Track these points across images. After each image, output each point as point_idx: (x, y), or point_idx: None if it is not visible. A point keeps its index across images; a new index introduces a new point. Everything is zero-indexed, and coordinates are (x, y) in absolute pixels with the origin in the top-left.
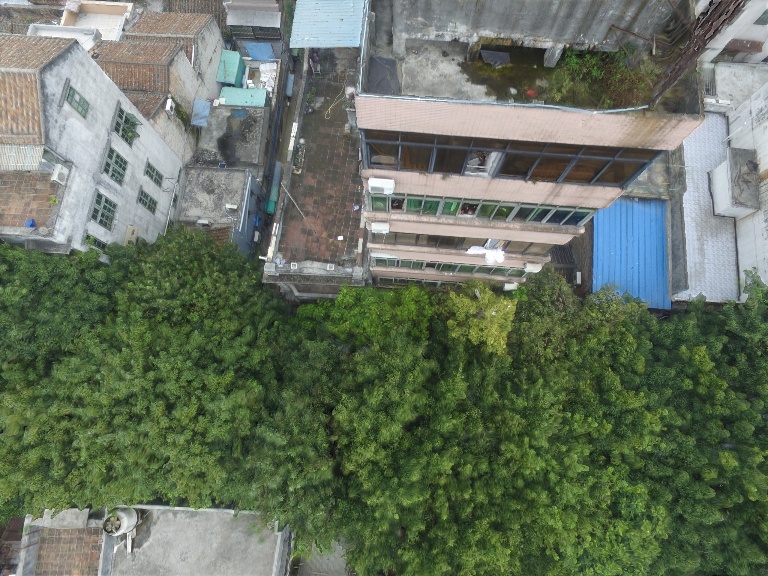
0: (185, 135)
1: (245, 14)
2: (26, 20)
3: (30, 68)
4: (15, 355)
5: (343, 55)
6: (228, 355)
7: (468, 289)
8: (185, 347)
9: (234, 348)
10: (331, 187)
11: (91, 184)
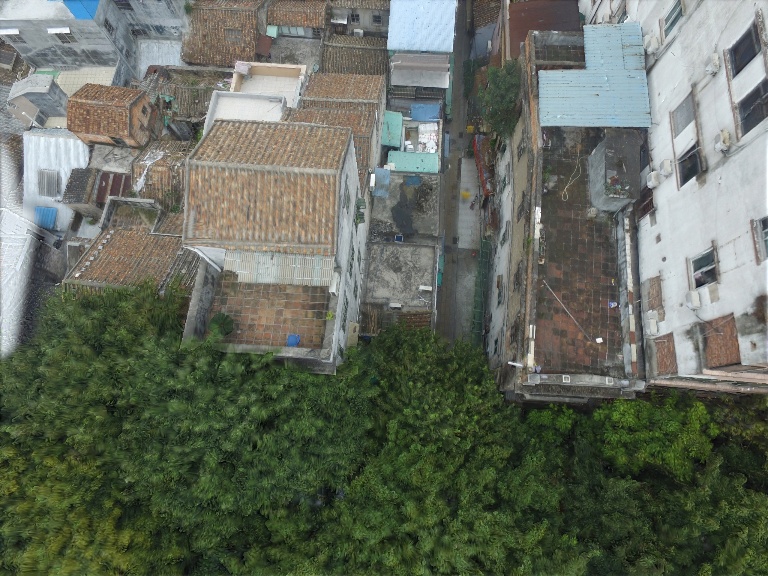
0: (369, 207)
1: (411, 74)
2: (188, 82)
3: (328, 168)
4: (283, 501)
5: (570, 128)
6: (527, 499)
7: (762, 405)
8: (474, 489)
9: (529, 489)
10: (580, 280)
11: (344, 286)
